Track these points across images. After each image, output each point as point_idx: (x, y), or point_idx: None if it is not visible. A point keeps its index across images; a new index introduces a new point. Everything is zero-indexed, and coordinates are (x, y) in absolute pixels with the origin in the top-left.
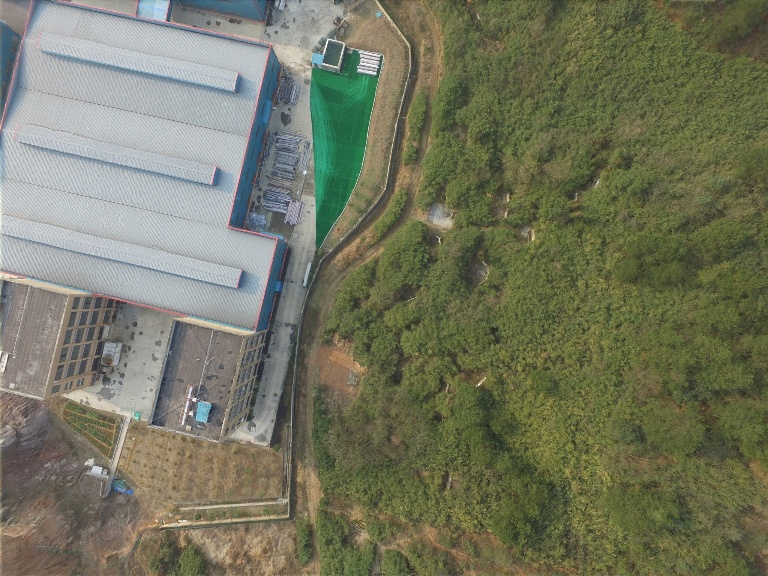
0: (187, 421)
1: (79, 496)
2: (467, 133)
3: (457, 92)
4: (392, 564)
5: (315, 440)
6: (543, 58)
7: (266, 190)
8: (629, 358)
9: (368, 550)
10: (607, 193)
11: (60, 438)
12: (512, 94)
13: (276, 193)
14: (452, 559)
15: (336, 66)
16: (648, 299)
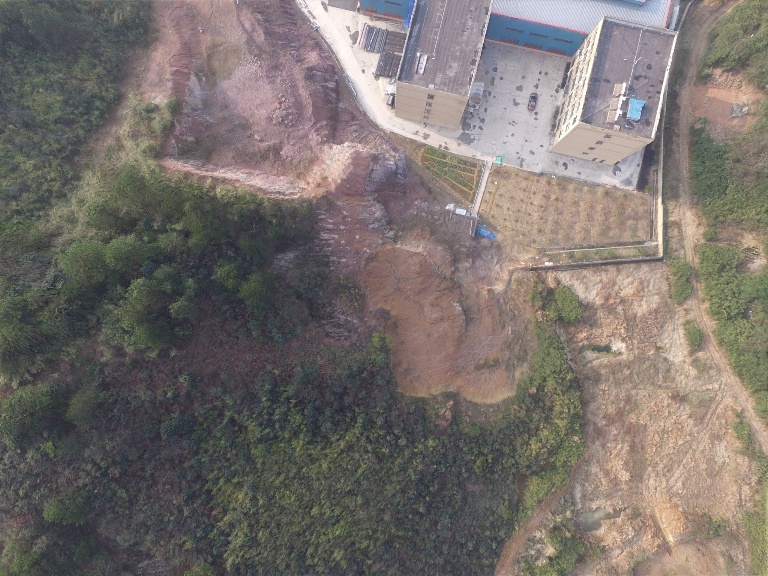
0: (615, 121)
1: (448, 234)
2: None
3: None
4: None
5: (702, 170)
6: None
7: None
8: None
9: None
10: None
11: (419, 183)
12: None
13: None
14: None
15: None
16: None
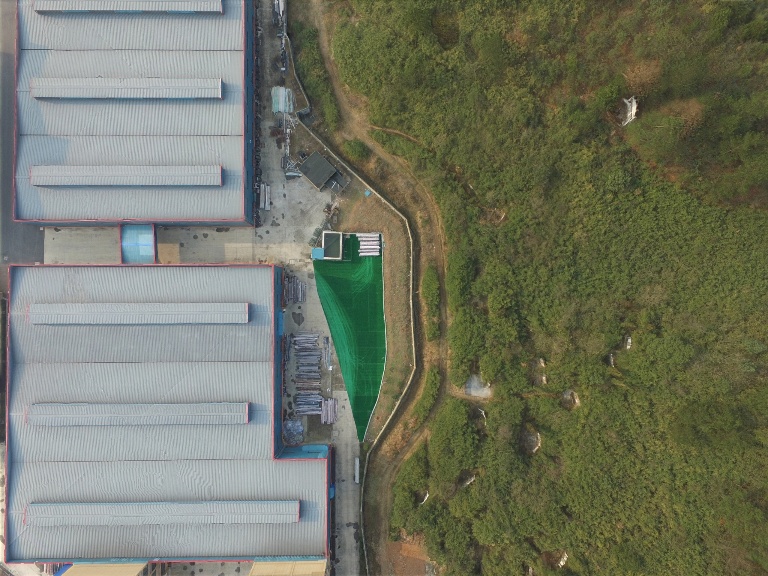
0: None
1: None
2: (485, 301)
3: (468, 267)
4: None
5: None
6: (548, 226)
7: (295, 395)
8: (705, 520)
9: None
10: (645, 358)
11: None
12: (524, 263)
13: (306, 396)
14: None
15: (338, 257)
16: (709, 458)
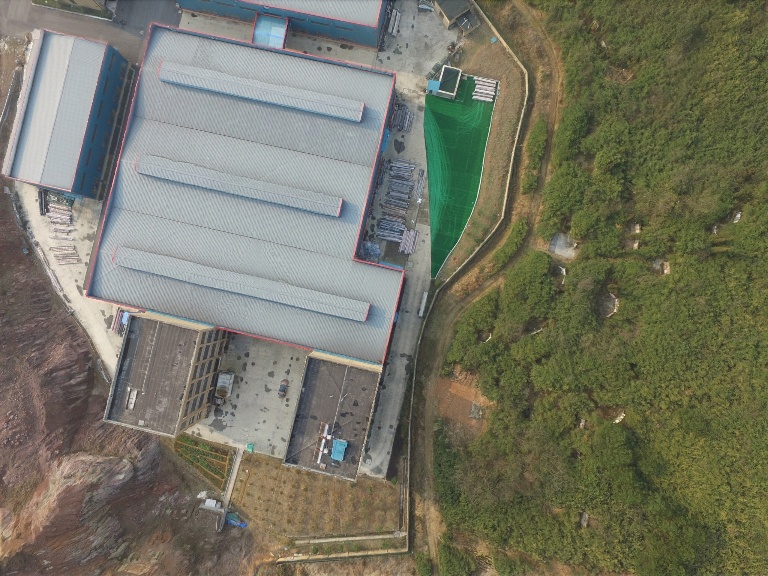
0: (321, 459)
1: (194, 530)
2: (591, 162)
3: (583, 121)
4: None
5: (438, 474)
6: (679, 88)
7: (380, 219)
8: None
9: None
10: (755, 228)
11: (172, 470)
12: (643, 124)
13: (390, 222)
14: None
15: (452, 93)
16: None
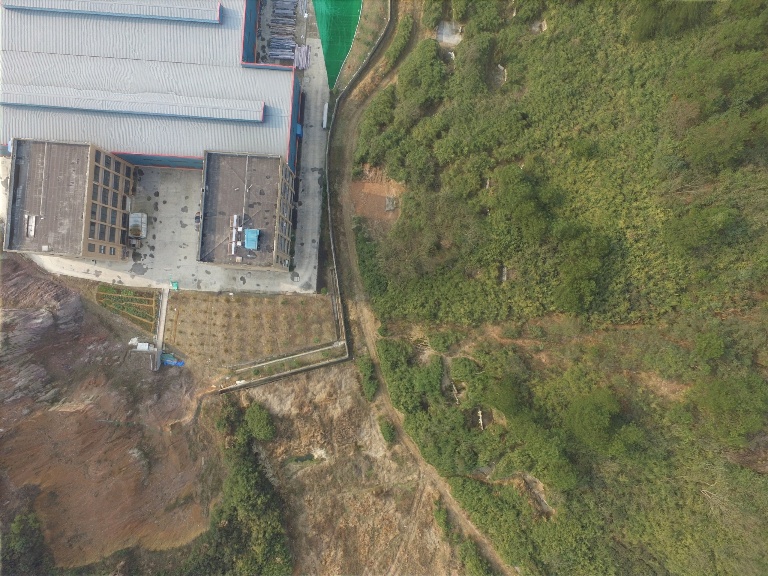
0: (236, 252)
1: (129, 373)
2: None
3: None
4: (462, 366)
5: (363, 270)
6: None
7: (269, 39)
8: (660, 107)
9: (435, 361)
10: None
11: (98, 322)
12: None
13: (280, 40)
14: (520, 348)
15: None
16: (668, 48)
